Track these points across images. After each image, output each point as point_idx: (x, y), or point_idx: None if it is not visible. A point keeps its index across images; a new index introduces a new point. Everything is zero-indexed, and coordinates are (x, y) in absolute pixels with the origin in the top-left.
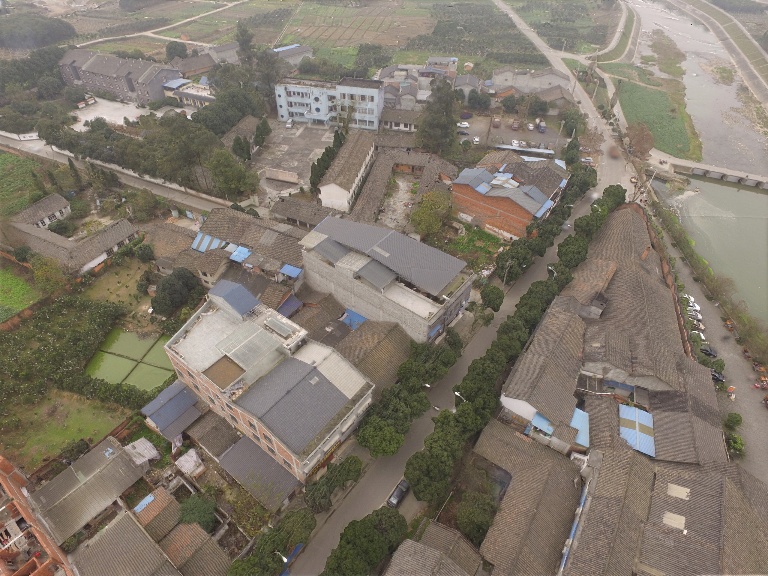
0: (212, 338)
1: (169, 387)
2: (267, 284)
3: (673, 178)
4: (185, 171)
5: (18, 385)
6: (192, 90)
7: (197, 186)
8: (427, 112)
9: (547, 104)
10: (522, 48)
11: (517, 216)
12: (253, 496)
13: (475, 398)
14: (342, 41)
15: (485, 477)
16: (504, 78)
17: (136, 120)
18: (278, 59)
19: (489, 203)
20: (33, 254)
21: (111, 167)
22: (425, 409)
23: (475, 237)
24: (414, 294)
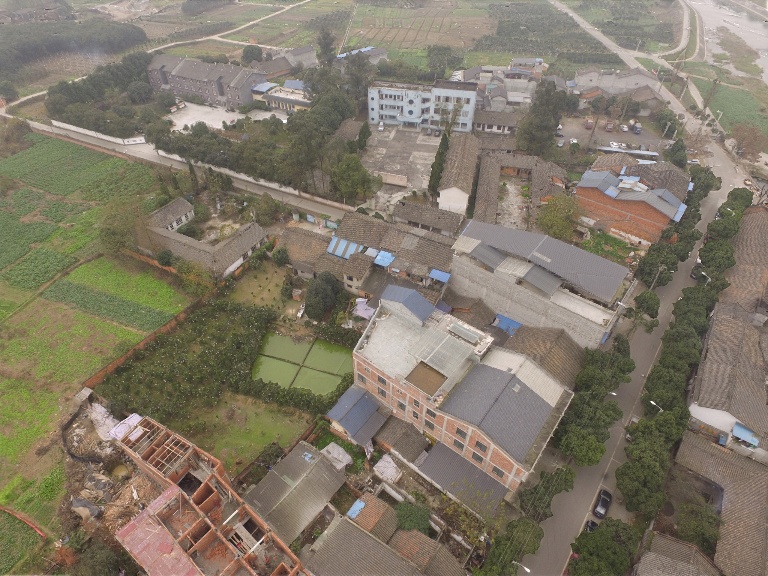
0: (394, 344)
1: (348, 392)
2: (415, 289)
3: None
4: (308, 175)
5: (195, 388)
6: (280, 94)
7: (313, 190)
8: (531, 114)
9: (639, 105)
10: (592, 48)
11: (650, 220)
12: (461, 503)
13: (672, 407)
14: (407, 43)
15: (692, 488)
16: (589, 79)
17: (230, 124)
18: None
19: (618, 207)
20: (177, 258)
21: (220, 171)
22: (618, 418)
23: (601, 241)
24: (581, 300)
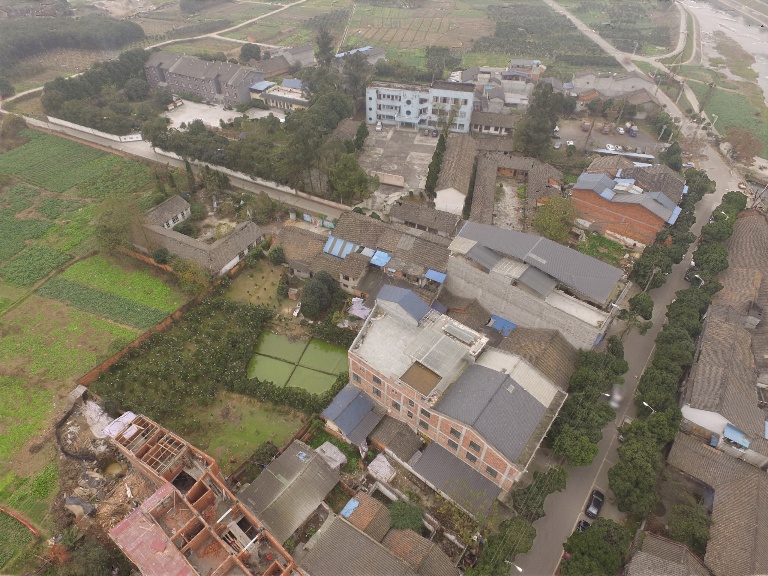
0: (389, 343)
1: (343, 391)
2: (411, 289)
3: None
4: (305, 174)
5: (189, 386)
6: (278, 92)
7: (310, 189)
8: (528, 116)
9: (636, 108)
10: (589, 50)
11: (645, 223)
12: (454, 503)
13: (664, 409)
14: (406, 43)
15: (683, 489)
16: (586, 81)
17: (228, 122)
18: None
19: (614, 209)
20: (173, 256)
21: (217, 169)
22: (611, 419)
23: (597, 243)
24: (576, 302)
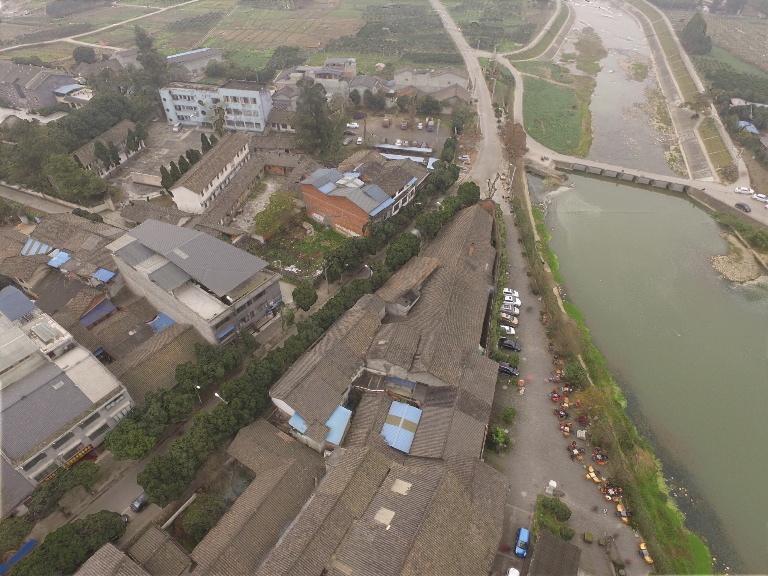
0: None
1: None
2: (81, 289)
3: (550, 174)
4: (31, 177)
5: None
6: (84, 95)
7: (52, 192)
8: None
9: (439, 103)
10: (441, 48)
11: (357, 215)
12: None
13: None
14: (264, 44)
15: None
16: (404, 78)
17: None
18: (182, 63)
19: (333, 203)
20: None
21: None
22: (186, 411)
23: (323, 237)
24: (207, 296)
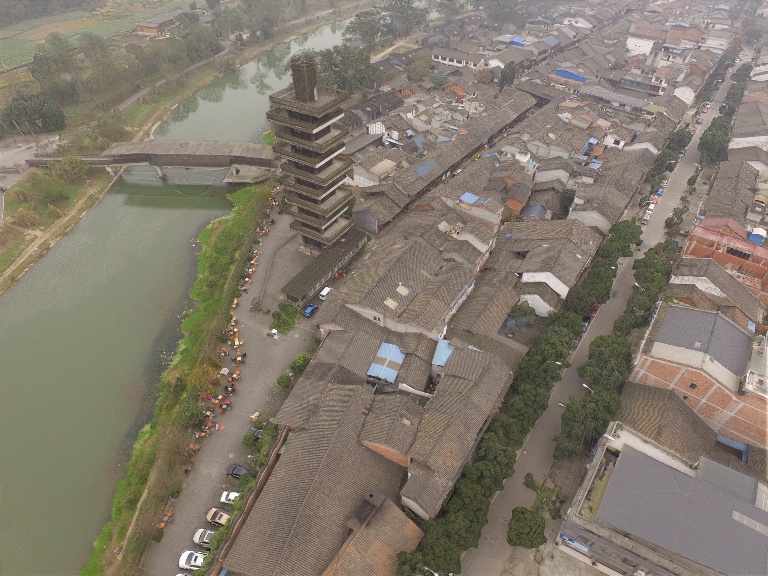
0: None
1: None
2: None
3: None
4: None
5: None
6: None
7: None
8: None
9: None
10: None
11: None
12: None
13: None
14: None
15: None
16: None
17: None
18: None
19: None
20: None
21: None
22: None
23: None
24: None
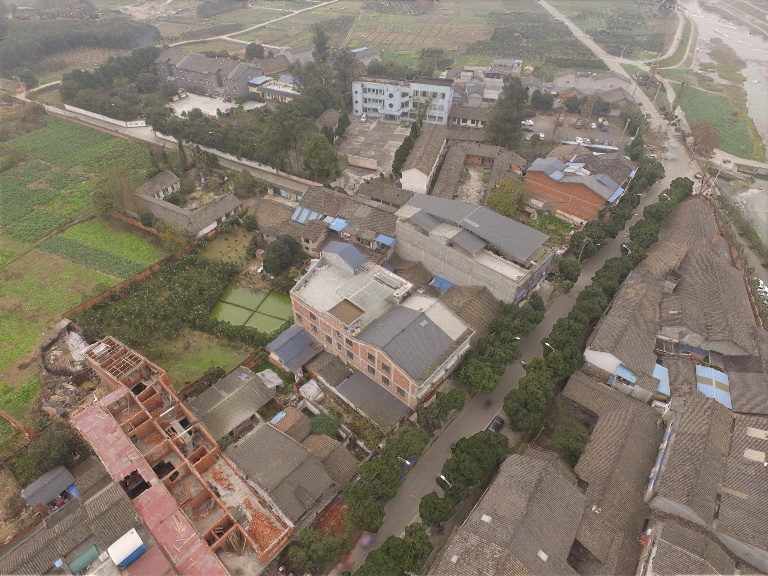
0: (328, 288)
1: (287, 330)
2: (363, 251)
3: (737, 176)
4: (282, 154)
5: (158, 323)
6: (274, 86)
7: (289, 169)
8: (498, 108)
9: (610, 105)
10: (580, 54)
11: (589, 201)
12: (369, 419)
13: (563, 349)
14: (404, 46)
15: (573, 417)
16: (566, 80)
17: (225, 112)
18: None
19: (562, 189)
20: (158, 219)
21: (209, 151)
22: (517, 357)
23: (546, 221)
24: (502, 261)
